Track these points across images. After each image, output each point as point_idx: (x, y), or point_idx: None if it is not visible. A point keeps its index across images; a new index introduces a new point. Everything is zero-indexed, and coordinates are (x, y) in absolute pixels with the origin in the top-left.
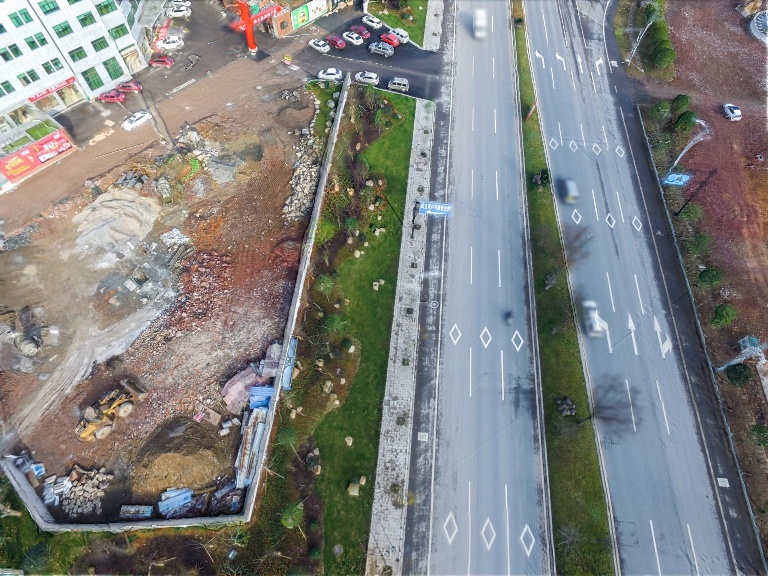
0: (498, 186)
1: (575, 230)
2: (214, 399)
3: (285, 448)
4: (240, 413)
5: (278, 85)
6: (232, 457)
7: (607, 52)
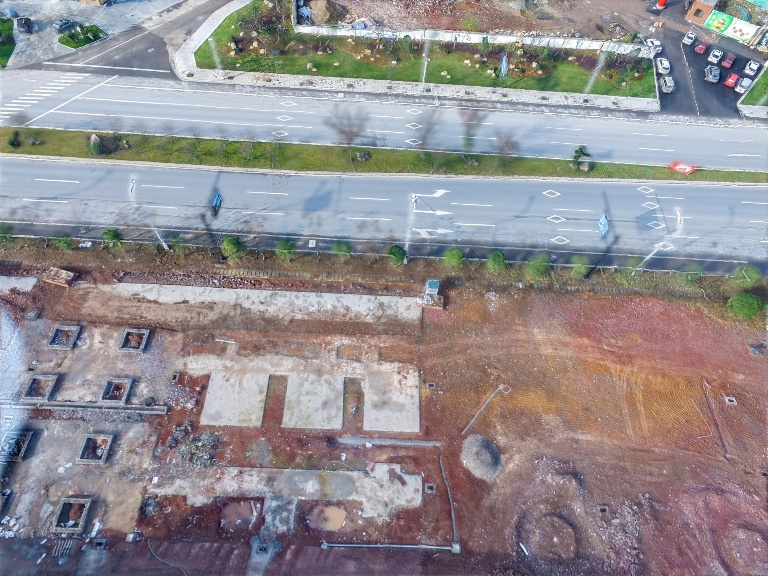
0: (568, 144)
1: (534, 190)
2: None
3: None
4: None
5: (625, 22)
6: None
7: None
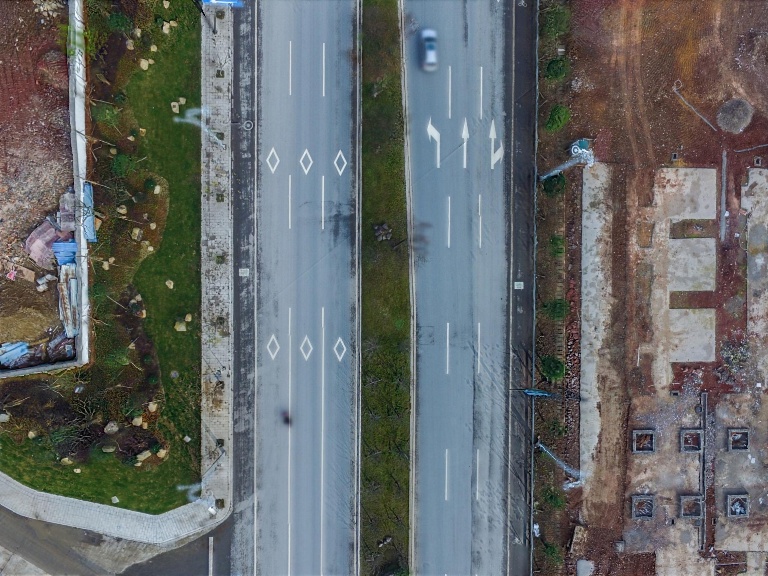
0: None
1: (420, 6)
2: (22, 256)
3: (104, 299)
4: (53, 268)
5: None
6: (58, 310)
7: None
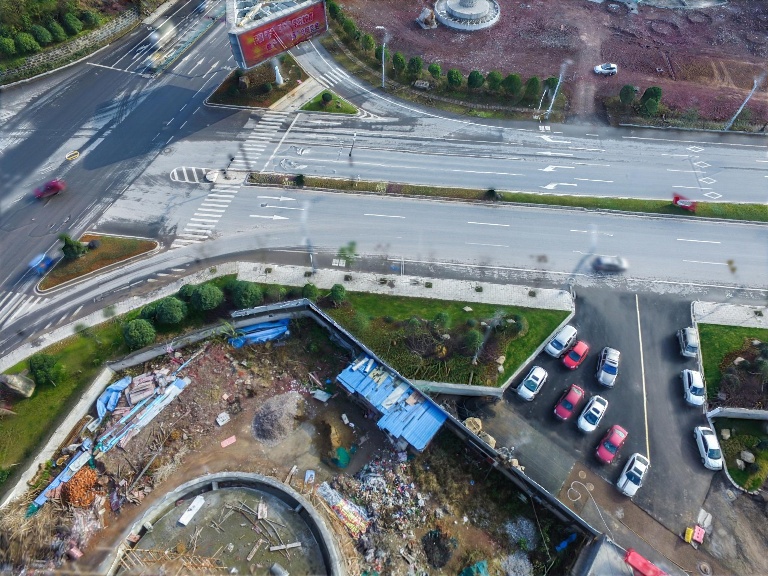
0: None
1: None
2: None
3: None
4: None
5: None
6: None
7: (524, 130)
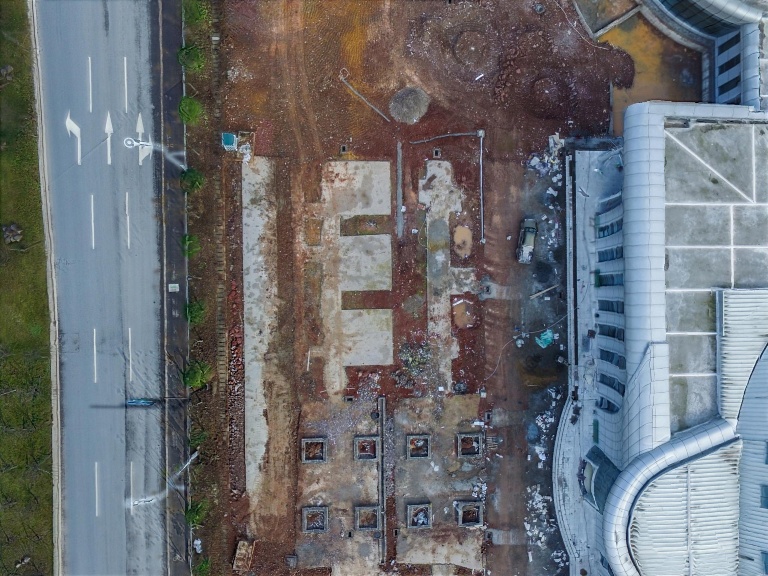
0: None
1: None
2: None
3: None
4: None
5: None
6: None
7: None
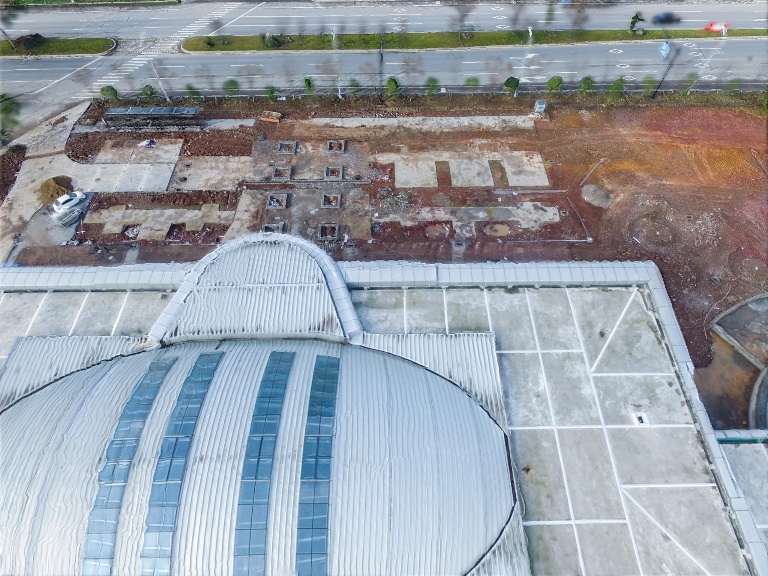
0: (623, 21)
1: (602, 50)
2: None
3: None
4: None
5: None
6: None
7: None
